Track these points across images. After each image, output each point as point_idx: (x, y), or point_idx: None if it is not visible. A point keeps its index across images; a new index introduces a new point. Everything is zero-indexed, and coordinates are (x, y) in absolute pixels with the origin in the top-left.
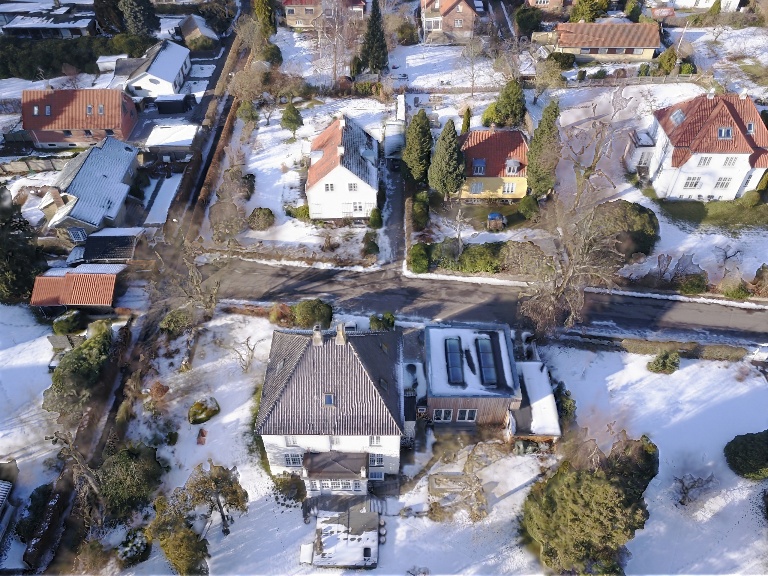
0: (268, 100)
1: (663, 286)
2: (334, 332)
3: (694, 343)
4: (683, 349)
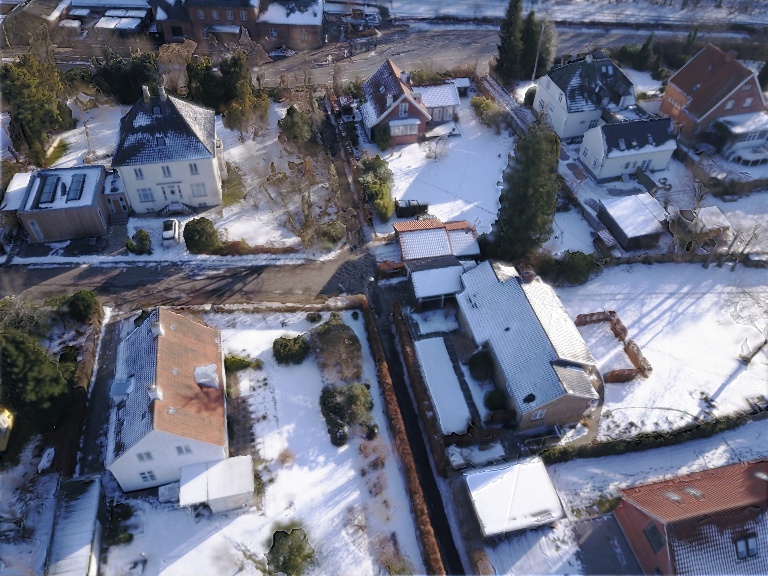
0: None
1: None
2: (163, 144)
3: None
4: None
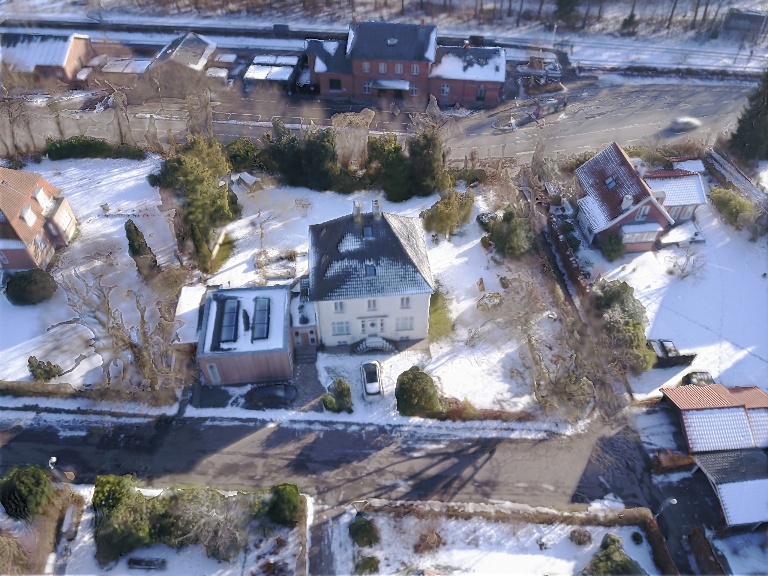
0: None
1: None
2: (373, 274)
3: None
4: (13, 381)
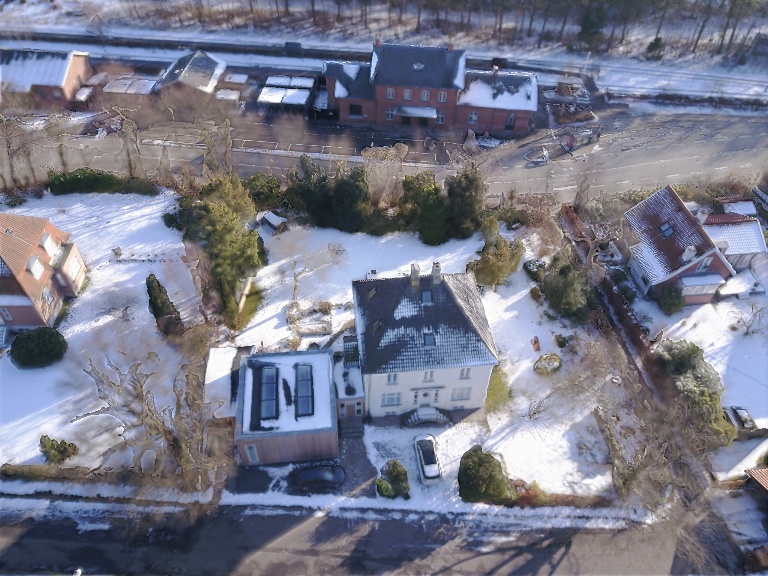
0: None
1: None
2: (432, 344)
3: (4, 470)
4: (22, 465)
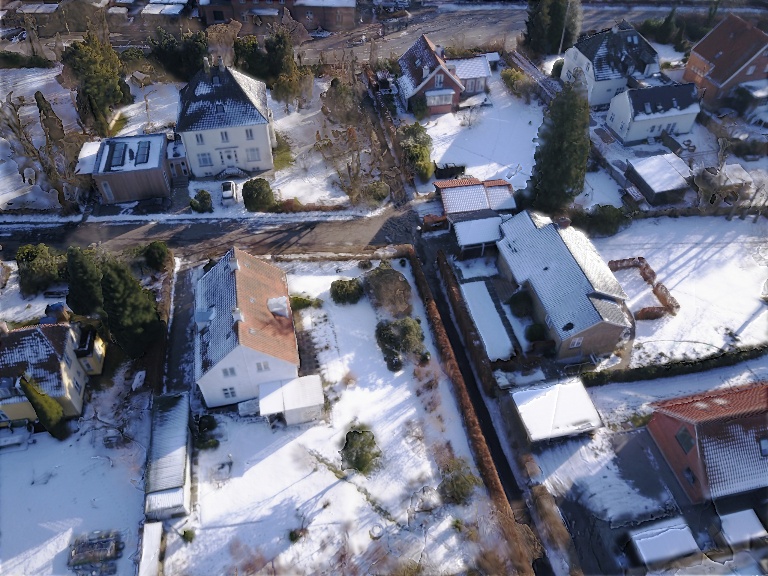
0: (434, 521)
1: None
2: (222, 111)
3: None
4: None
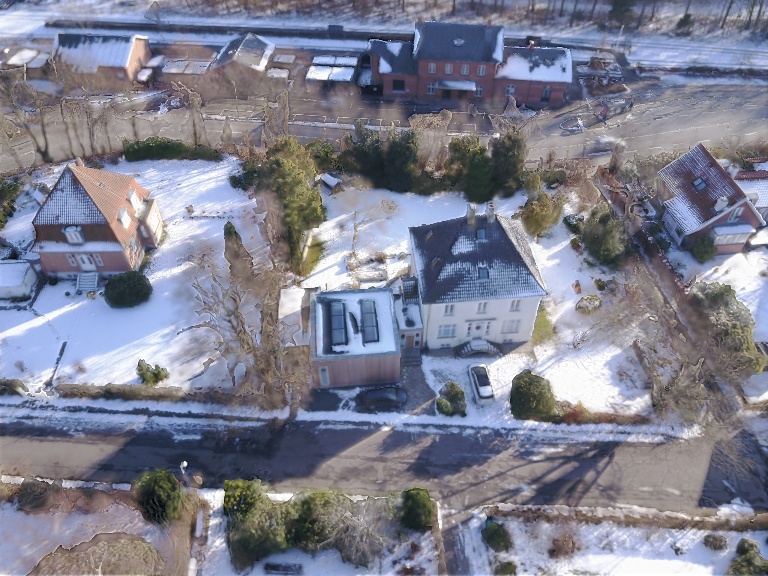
0: None
1: (82, 493)
2: (486, 277)
3: (109, 388)
4: None
